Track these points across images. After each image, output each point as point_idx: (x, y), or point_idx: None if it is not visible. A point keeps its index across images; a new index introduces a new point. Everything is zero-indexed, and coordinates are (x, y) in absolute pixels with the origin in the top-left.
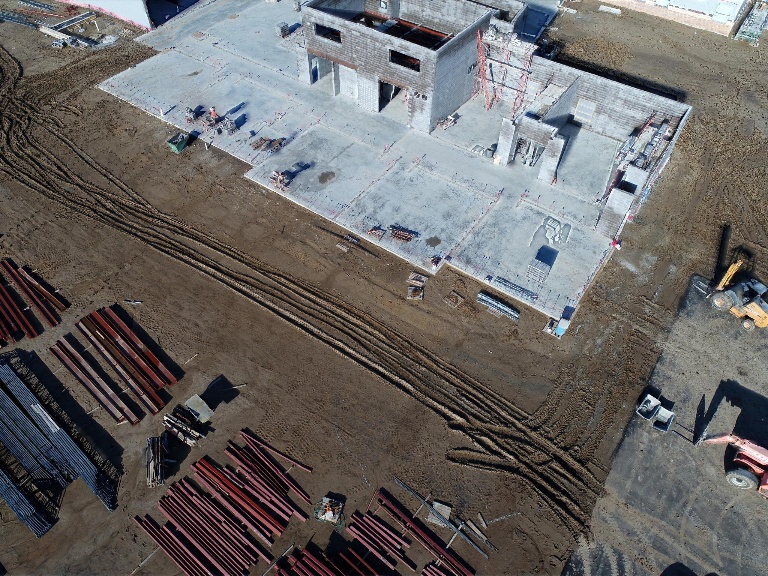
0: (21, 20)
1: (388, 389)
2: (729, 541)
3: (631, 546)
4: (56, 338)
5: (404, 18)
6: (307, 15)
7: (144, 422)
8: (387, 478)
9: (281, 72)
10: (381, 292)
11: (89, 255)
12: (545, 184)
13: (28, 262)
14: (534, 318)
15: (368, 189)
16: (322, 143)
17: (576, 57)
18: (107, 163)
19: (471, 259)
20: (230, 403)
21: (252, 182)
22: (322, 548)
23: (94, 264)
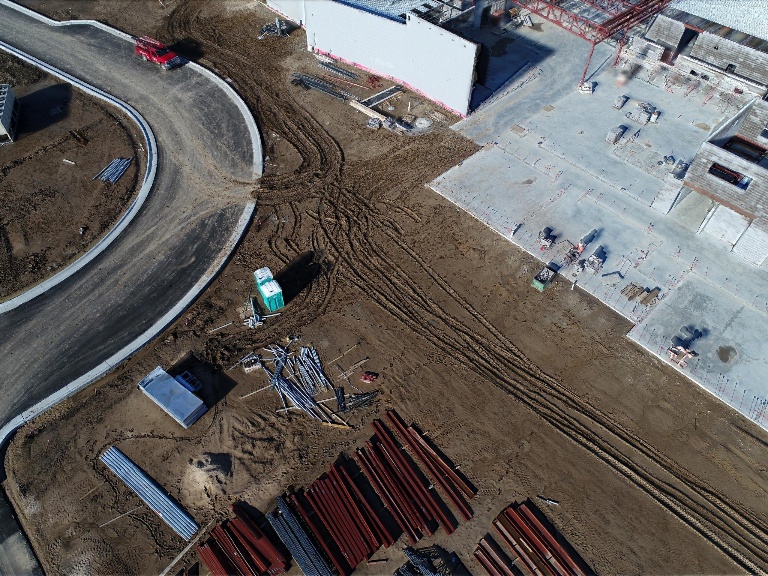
0: (327, 88)
1: None
2: None
3: None
4: (475, 538)
5: None
6: (708, 152)
7: None
8: None
9: (625, 192)
10: None
11: (479, 421)
12: None
13: (415, 419)
14: None
15: None
16: (705, 301)
17: None
18: (465, 292)
19: None
20: None
21: (638, 346)
22: None
23: (488, 435)
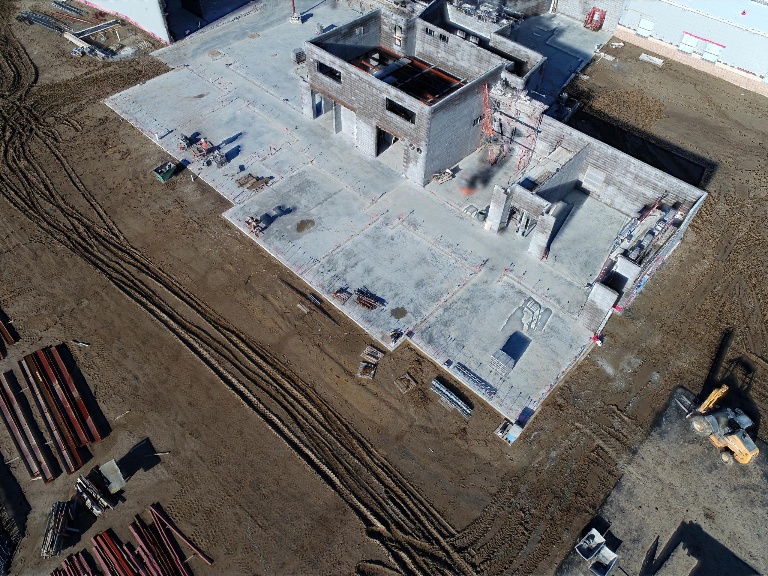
0: (49, 23)
1: (313, 479)
2: None
3: None
4: None
5: (419, 57)
6: (310, 51)
7: (58, 481)
8: None
9: (287, 102)
10: (331, 364)
11: (51, 286)
12: (534, 258)
13: None
14: (488, 416)
15: (345, 244)
16: (310, 186)
17: (602, 111)
18: (93, 186)
19: (434, 338)
20: (148, 472)
21: (229, 223)
22: None
23: (53, 296)
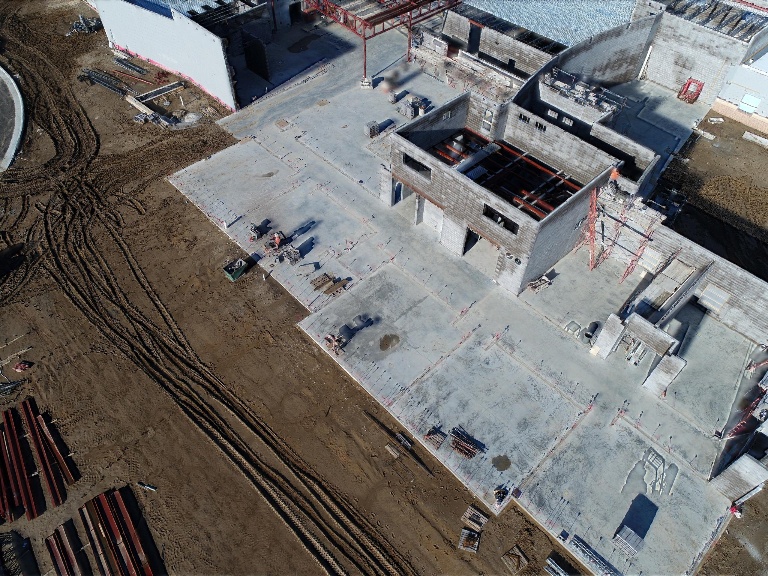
0: (111, 84)
1: None
2: None
3: None
4: (55, 524)
5: (508, 141)
6: (397, 143)
7: None
8: None
9: (362, 184)
10: (428, 530)
11: (114, 409)
12: (651, 395)
13: (50, 407)
14: None
15: (434, 368)
16: (391, 291)
17: (708, 203)
18: (157, 283)
19: (545, 500)
20: None
21: (305, 335)
22: None
23: (116, 423)
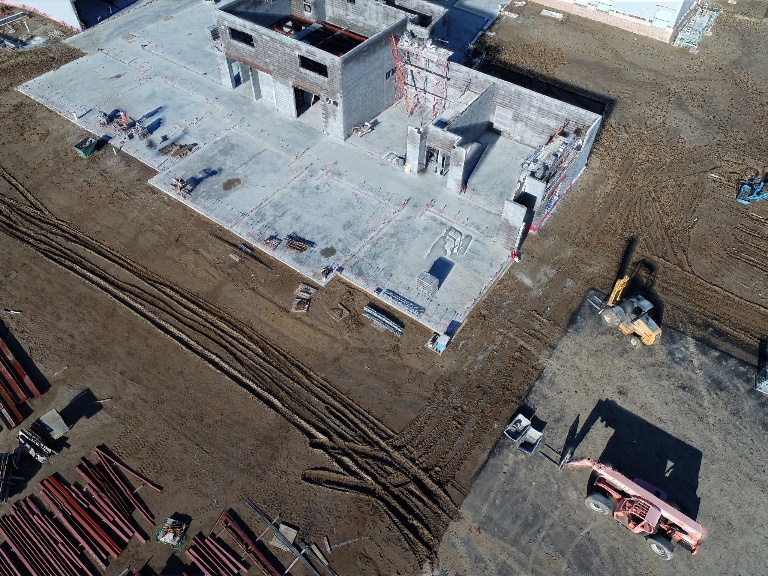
0: None
1: (255, 405)
2: (578, 569)
3: (476, 573)
4: None
5: (330, 22)
6: (220, 19)
7: None
8: (237, 499)
9: (205, 75)
10: (266, 304)
11: None
12: (453, 193)
13: None
14: (418, 333)
15: (272, 197)
16: (233, 149)
17: (509, 63)
18: (12, 167)
19: (363, 271)
20: (91, 418)
21: (155, 189)
22: (157, 572)
23: None
